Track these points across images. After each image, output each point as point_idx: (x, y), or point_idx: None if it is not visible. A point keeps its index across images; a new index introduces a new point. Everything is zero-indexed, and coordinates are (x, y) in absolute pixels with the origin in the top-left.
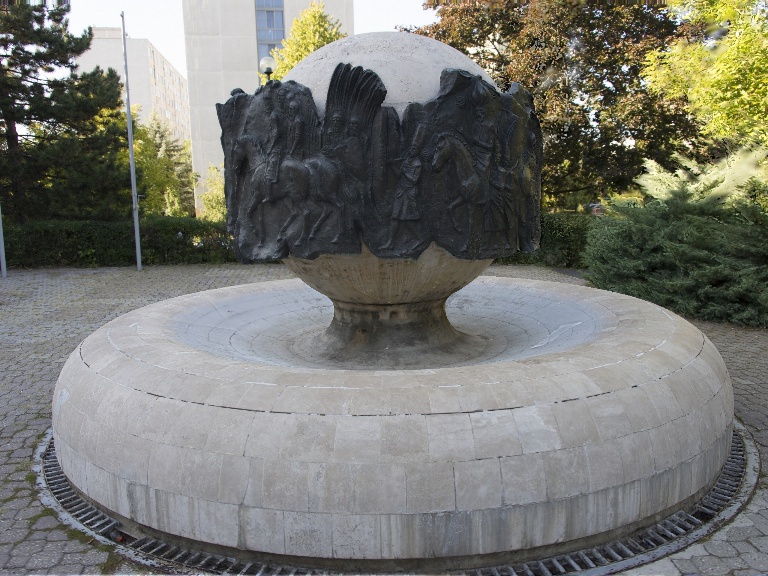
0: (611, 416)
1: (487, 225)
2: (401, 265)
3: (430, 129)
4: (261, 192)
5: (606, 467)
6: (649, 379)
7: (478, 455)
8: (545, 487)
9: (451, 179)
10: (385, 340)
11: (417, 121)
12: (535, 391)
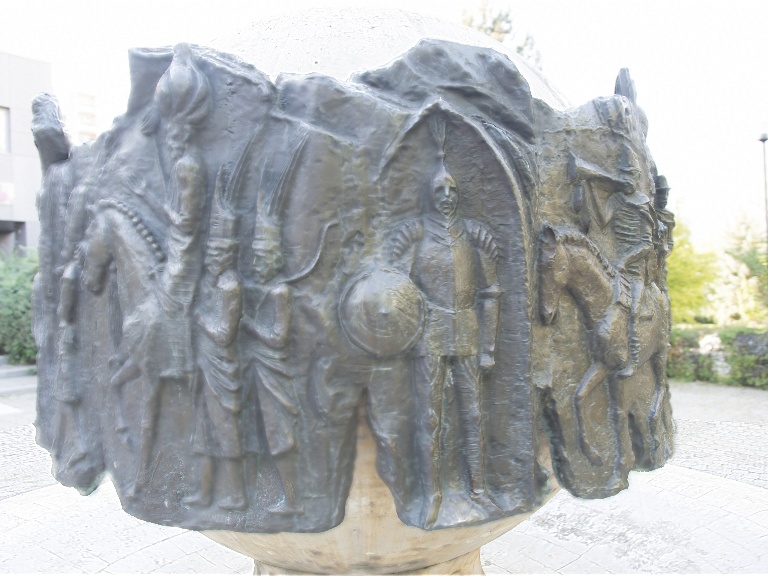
0: None
1: (198, 437)
2: None
3: (90, 195)
4: None
5: None
6: None
7: None
8: None
9: (116, 310)
10: None
11: (78, 180)
12: None
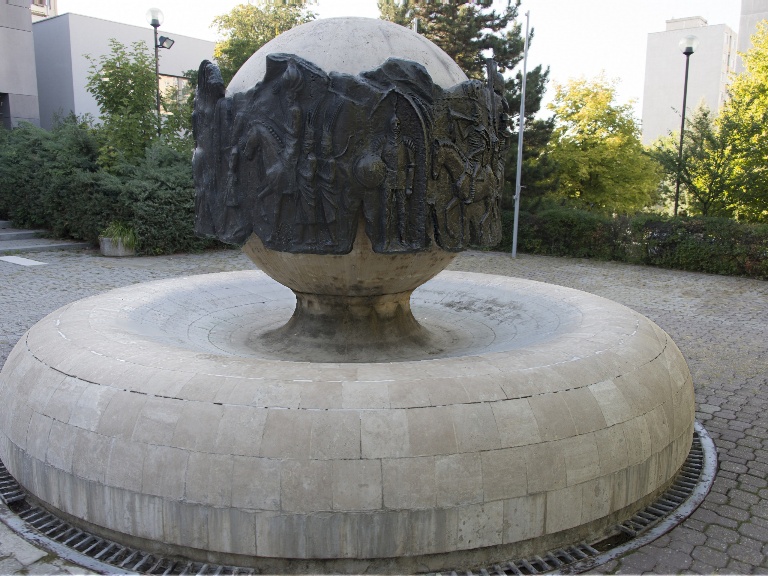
0: (158, 421)
1: (298, 217)
2: (264, 251)
3: (246, 117)
4: None
5: (125, 467)
6: (249, 403)
7: (46, 411)
8: (72, 460)
9: (261, 167)
10: (299, 327)
11: (238, 110)
12: (126, 375)
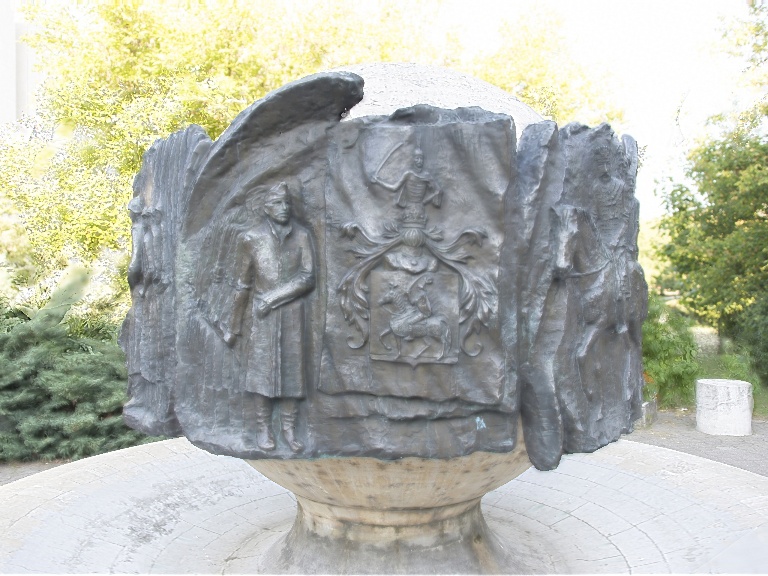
0: None
1: None
2: None
3: None
4: (610, 315)
5: None
6: None
7: None
8: None
9: None
10: None
11: None
12: None
